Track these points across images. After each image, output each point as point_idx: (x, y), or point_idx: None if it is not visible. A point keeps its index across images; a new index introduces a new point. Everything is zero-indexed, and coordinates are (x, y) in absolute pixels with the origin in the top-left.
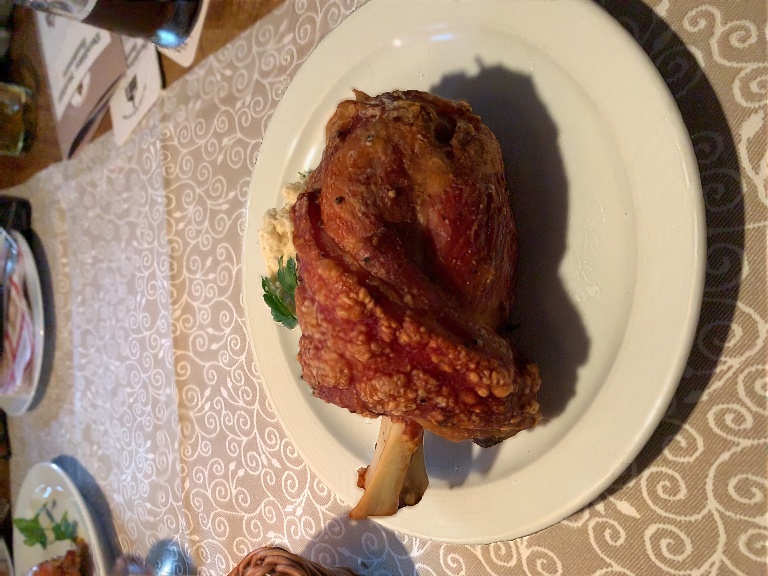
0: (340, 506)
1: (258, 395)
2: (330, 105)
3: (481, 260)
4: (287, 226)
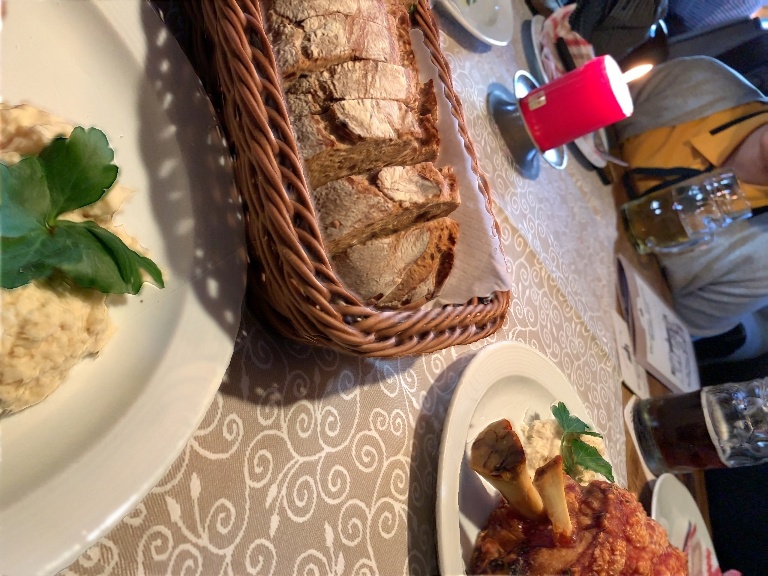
0: None
1: None
2: None
3: None
4: None
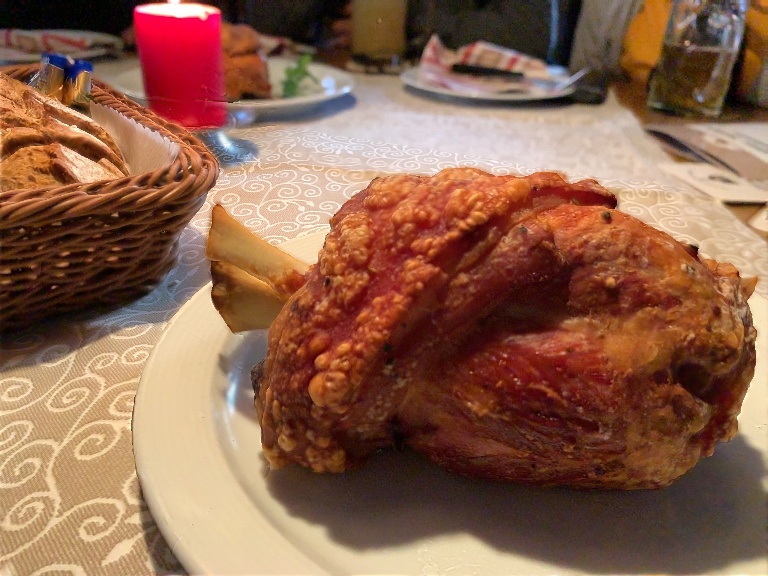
0: None
1: None
2: None
3: (501, 397)
4: None
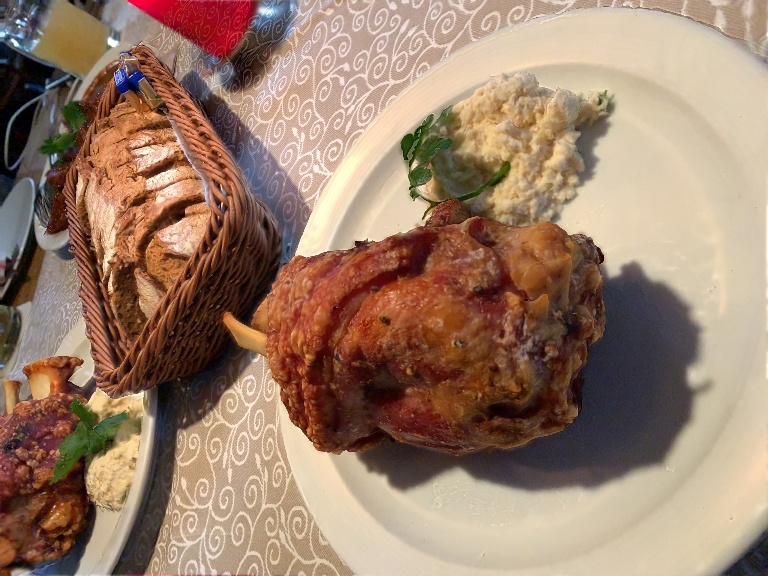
0: None
1: (399, 82)
2: (694, 128)
3: None
4: (500, 127)
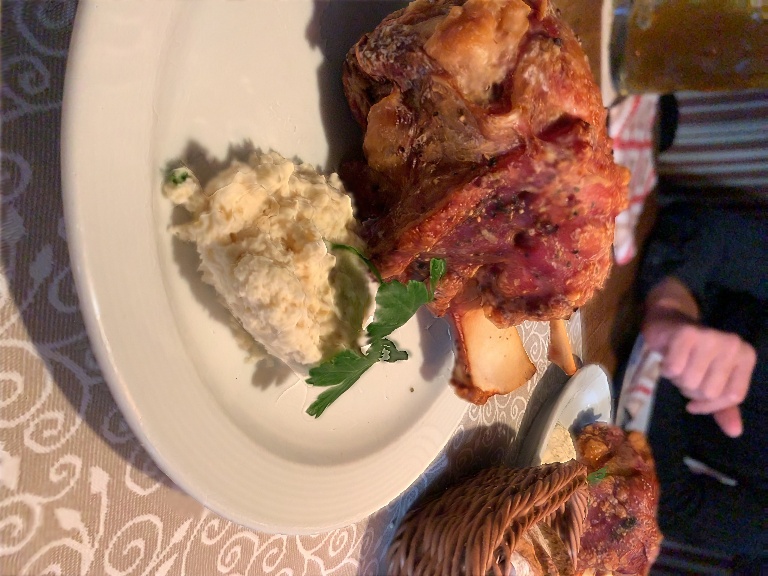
0: (364, 519)
1: None
2: (189, 4)
3: None
4: None
